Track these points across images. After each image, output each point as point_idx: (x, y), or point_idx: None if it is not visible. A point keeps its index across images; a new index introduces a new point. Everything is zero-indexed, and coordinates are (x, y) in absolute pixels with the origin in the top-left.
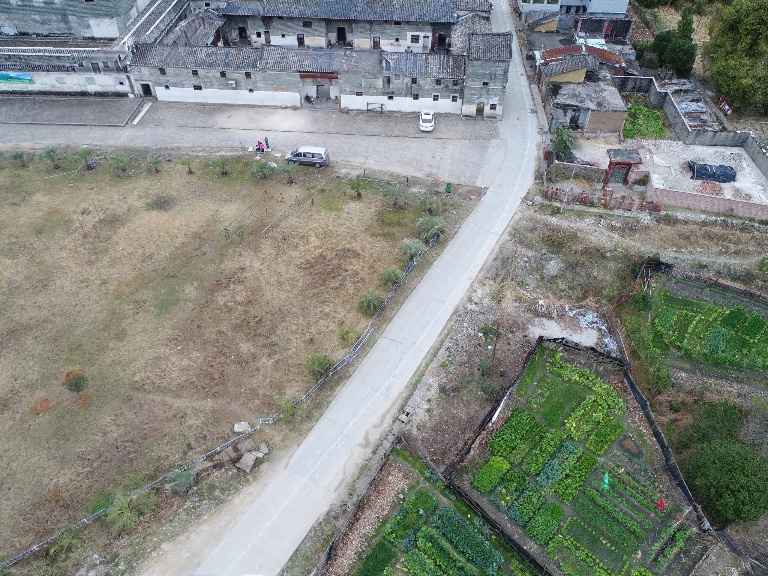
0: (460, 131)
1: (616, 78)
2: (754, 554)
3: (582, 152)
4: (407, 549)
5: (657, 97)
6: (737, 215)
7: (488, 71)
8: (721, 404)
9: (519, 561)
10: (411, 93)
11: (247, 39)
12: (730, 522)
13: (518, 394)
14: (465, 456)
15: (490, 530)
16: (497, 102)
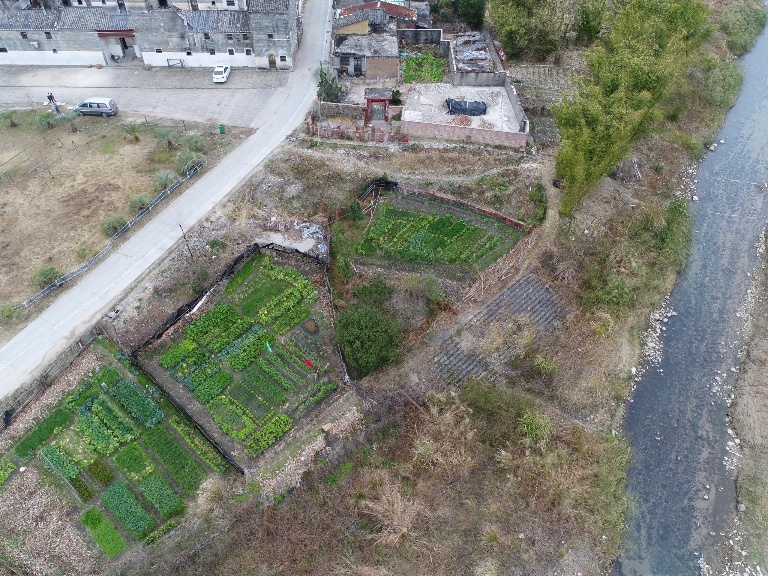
0: (252, 82)
1: (408, 31)
2: (376, 396)
3: (358, 96)
4: (82, 413)
5: (442, 47)
6: (475, 142)
7: (270, 24)
8: (375, 282)
9: (178, 416)
10: (207, 48)
11: (71, 7)
12: (367, 375)
13: (226, 292)
14: (155, 340)
15: (159, 394)
16: (286, 54)
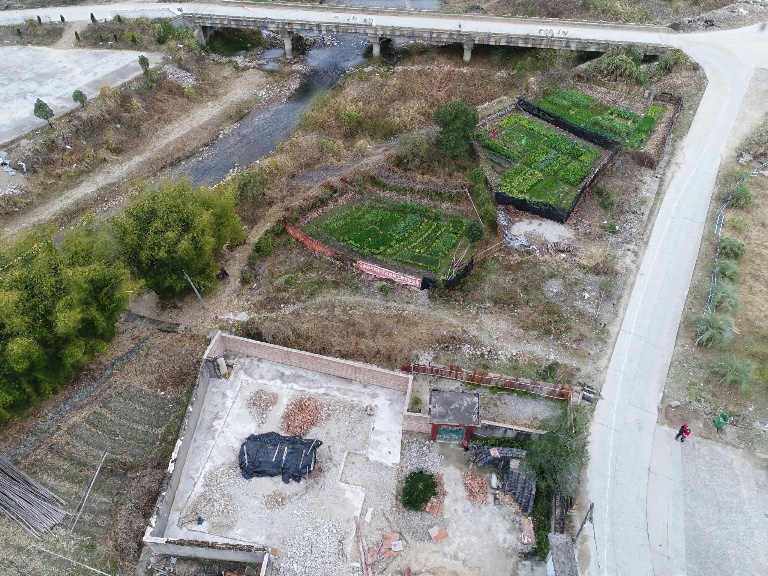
0: None
1: None
2: None
3: (494, 538)
4: None
5: None
6: None
7: None
8: None
9: None
10: None
11: None
12: None
13: None
14: None
15: None
16: None
